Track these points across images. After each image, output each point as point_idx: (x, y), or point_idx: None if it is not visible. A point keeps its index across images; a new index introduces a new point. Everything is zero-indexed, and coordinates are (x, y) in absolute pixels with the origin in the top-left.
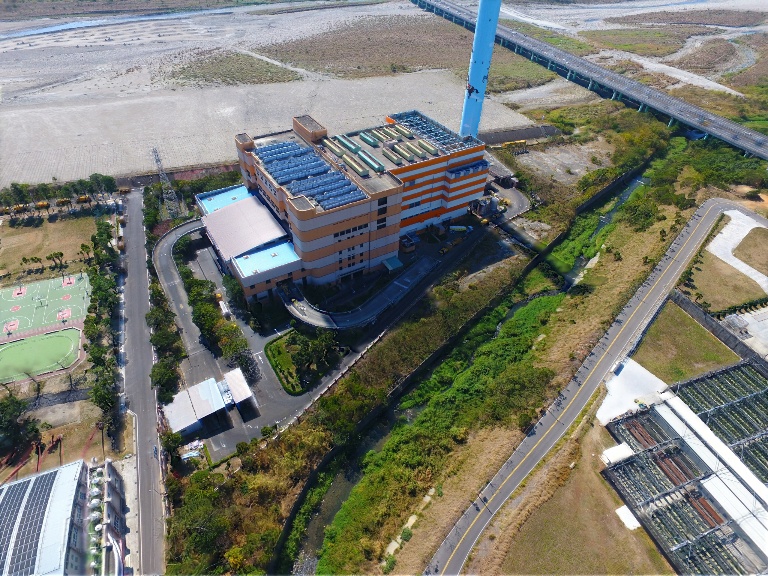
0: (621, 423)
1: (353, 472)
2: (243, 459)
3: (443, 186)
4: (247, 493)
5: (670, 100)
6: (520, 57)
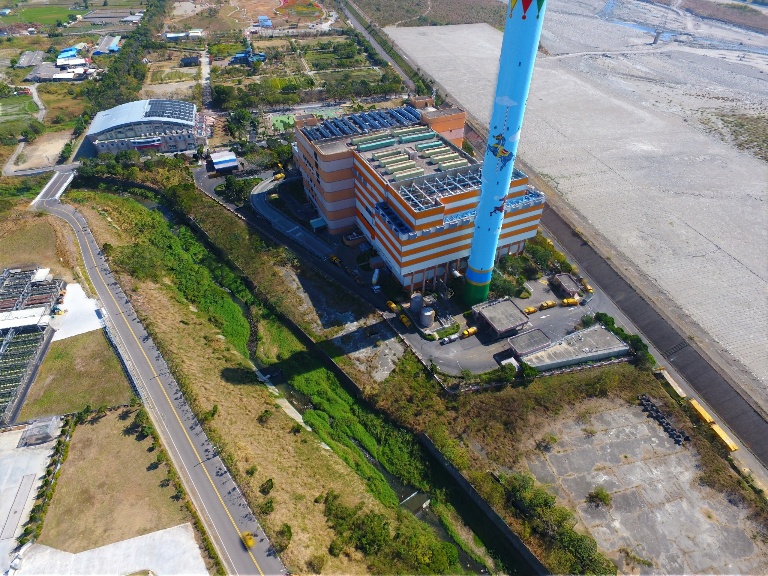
0: None
1: None
2: None
3: None
4: None
5: None
6: None
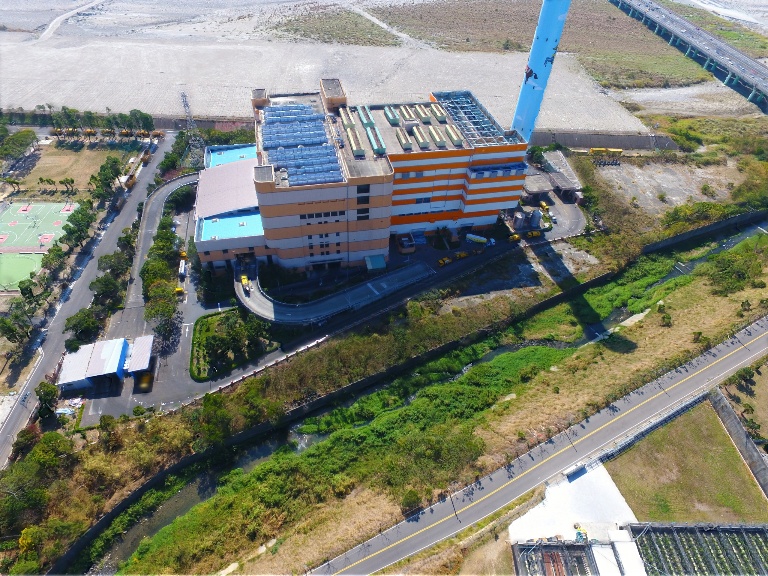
0: (534, 550)
1: (208, 486)
2: (100, 434)
3: (463, 185)
4: None
5: None
6: (673, 50)
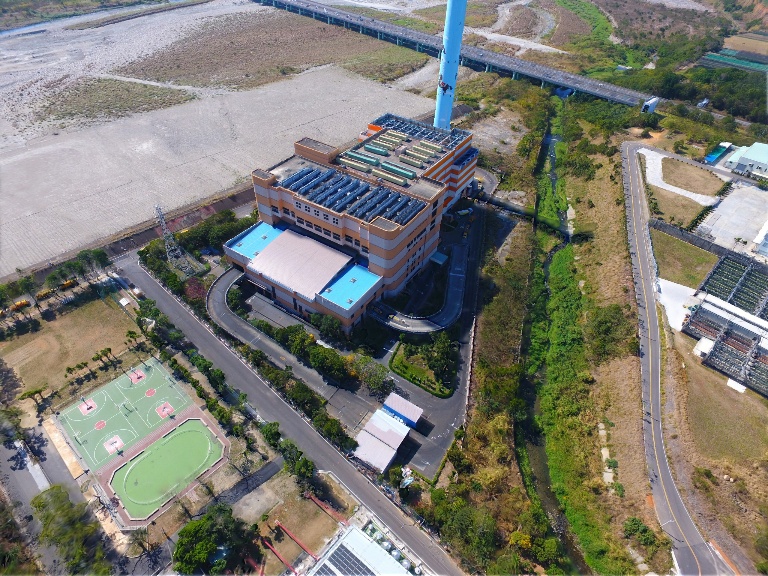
0: (690, 325)
1: (535, 438)
2: (460, 464)
3: (450, 178)
4: (480, 490)
5: (533, 66)
6: (386, 43)
